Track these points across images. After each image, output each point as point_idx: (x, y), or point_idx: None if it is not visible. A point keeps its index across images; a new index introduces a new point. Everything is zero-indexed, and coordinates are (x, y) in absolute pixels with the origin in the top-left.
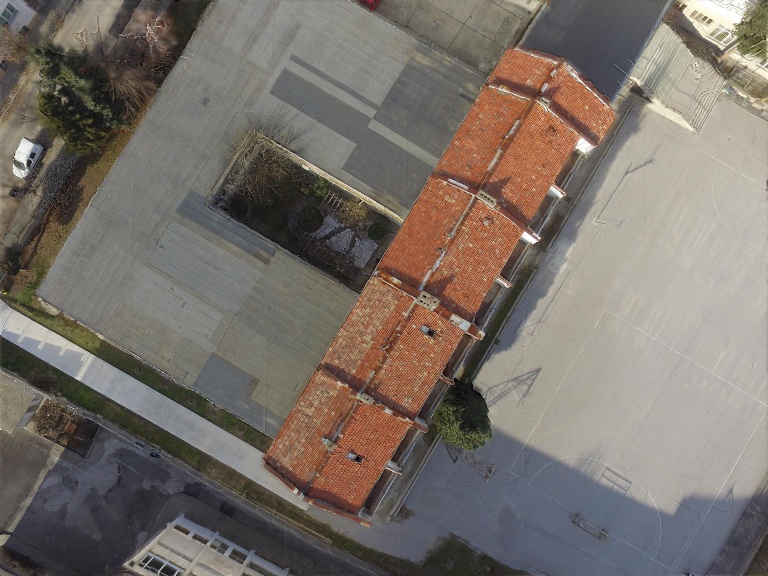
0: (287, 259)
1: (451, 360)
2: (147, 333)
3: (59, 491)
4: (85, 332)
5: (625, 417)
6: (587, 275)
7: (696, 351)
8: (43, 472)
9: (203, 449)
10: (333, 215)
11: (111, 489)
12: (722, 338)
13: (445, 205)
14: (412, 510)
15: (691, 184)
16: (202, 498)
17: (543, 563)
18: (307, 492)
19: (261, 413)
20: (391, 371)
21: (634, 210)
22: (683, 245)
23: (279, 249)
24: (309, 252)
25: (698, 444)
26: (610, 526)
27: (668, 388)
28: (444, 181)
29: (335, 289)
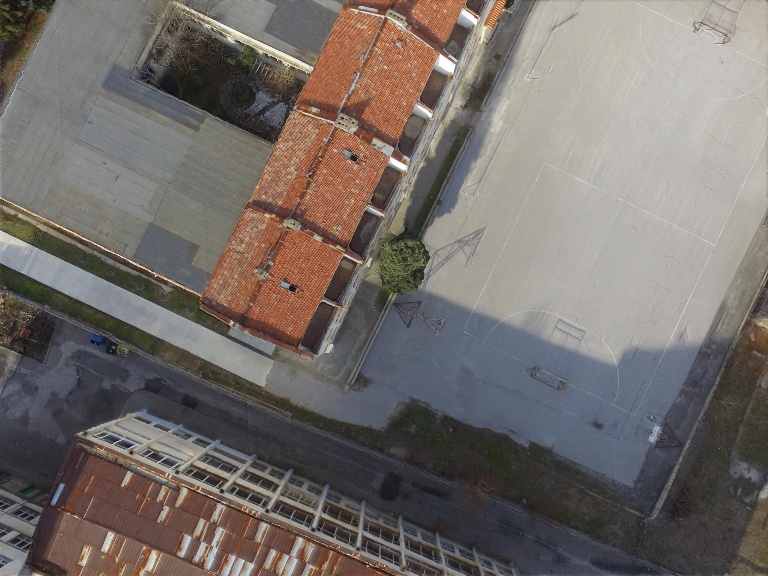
0: (217, 125)
1: (383, 198)
2: (83, 209)
3: (19, 398)
4: (26, 225)
5: (573, 267)
6: (524, 131)
7: (638, 196)
8: (2, 381)
9: (155, 334)
10: (265, 91)
11: (71, 392)
12: (663, 181)
13: (358, 32)
14: (370, 378)
15: (619, 32)
16: (163, 393)
17: (504, 419)
18: (242, 322)
19: (203, 278)
20: (316, 197)
21: (565, 63)
22: (616, 93)
23: (208, 116)
24: (241, 122)
25: (648, 288)
26: (568, 376)
27: (613, 235)
28: (355, 9)
29: (267, 150)
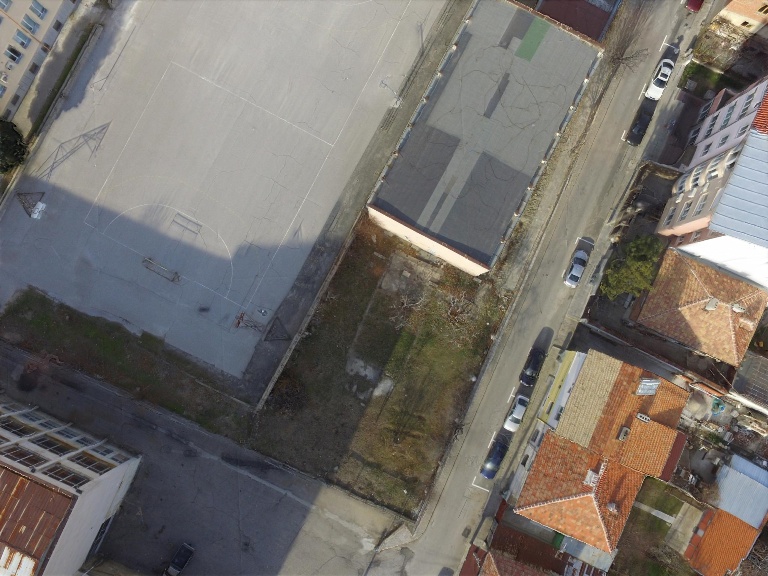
0: None
1: None
2: None
3: None
4: None
5: (193, 163)
6: (153, 29)
7: (260, 96)
8: None
9: None
10: None
11: None
12: (286, 82)
13: None
14: None
15: None
16: None
17: (119, 308)
18: None
19: None
20: None
21: None
22: None
23: None
24: None
25: (265, 185)
26: (183, 269)
27: (234, 133)
28: None
29: None
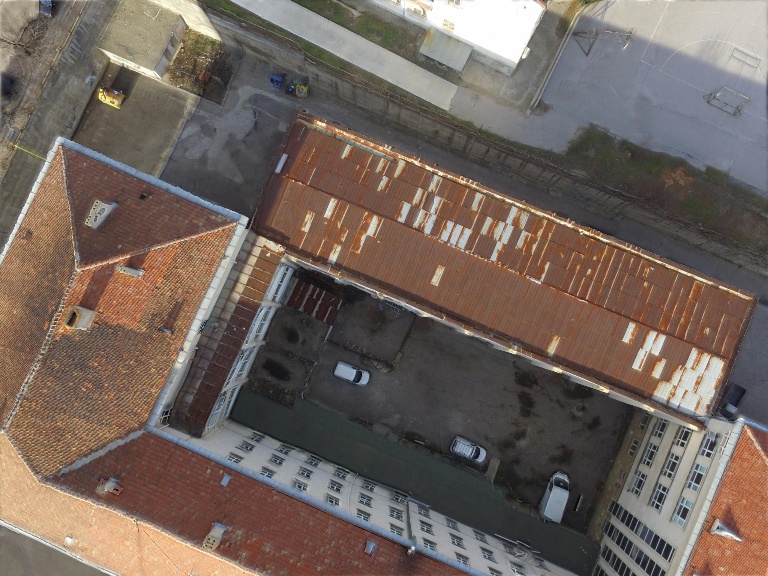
0: None
1: None
2: None
3: (198, 139)
4: None
5: None
6: None
7: None
8: (181, 122)
9: (344, 57)
10: None
11: (249, 134)
12: None
13: None
14: (550, 104)
15: None
16: None
17: (682, 143)
18: None
19: None
20: None
21: None
22: None
23: None
24: None
25: None
26: None
27: None
28: None
29: None
